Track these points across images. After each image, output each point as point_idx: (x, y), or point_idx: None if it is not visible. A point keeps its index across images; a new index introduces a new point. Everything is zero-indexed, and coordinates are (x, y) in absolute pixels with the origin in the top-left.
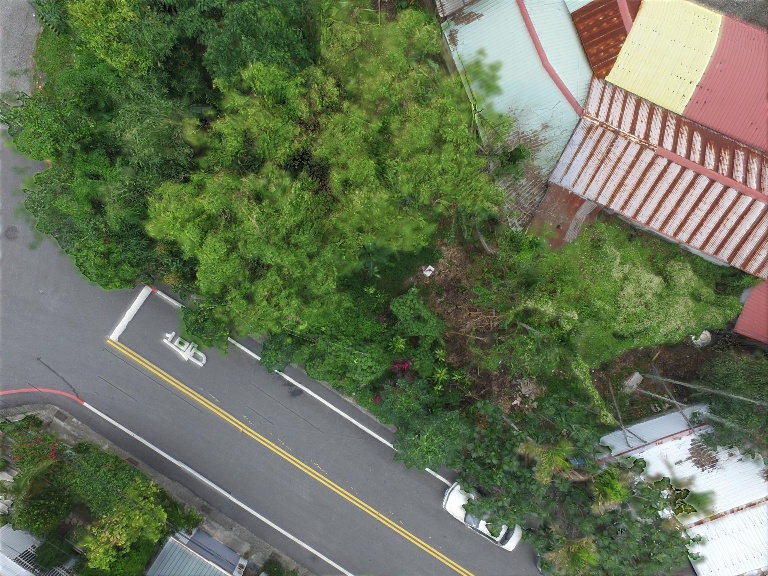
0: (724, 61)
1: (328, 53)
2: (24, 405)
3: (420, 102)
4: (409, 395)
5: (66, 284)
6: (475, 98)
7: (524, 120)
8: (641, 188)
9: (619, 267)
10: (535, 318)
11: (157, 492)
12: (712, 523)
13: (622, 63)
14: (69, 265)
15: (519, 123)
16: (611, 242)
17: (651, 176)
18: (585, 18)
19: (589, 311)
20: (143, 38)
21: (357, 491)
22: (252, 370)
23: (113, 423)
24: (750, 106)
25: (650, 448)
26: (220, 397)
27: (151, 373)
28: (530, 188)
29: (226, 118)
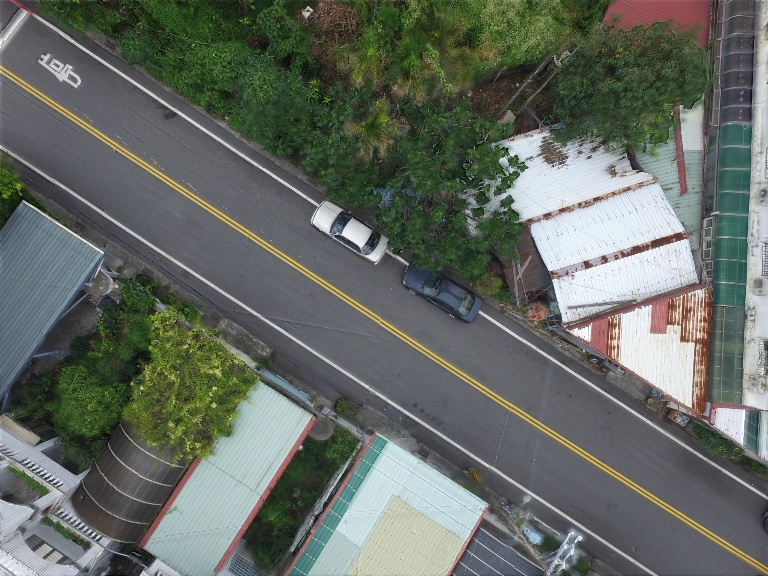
0: None
1: None
2: None
3: None
4: None
5: None
6: None
7: None
8: None
9: None
10: None
11: None
12: (563, 221)
13: None
14: None
15: None
16: None
17: None
18: None
19: None
20: None
21: (228, 210)
22: (126, 93)
23: None
24: None
25: (502, 144)
26: (94, 118)
27: (25, 92)
28: None
29: None
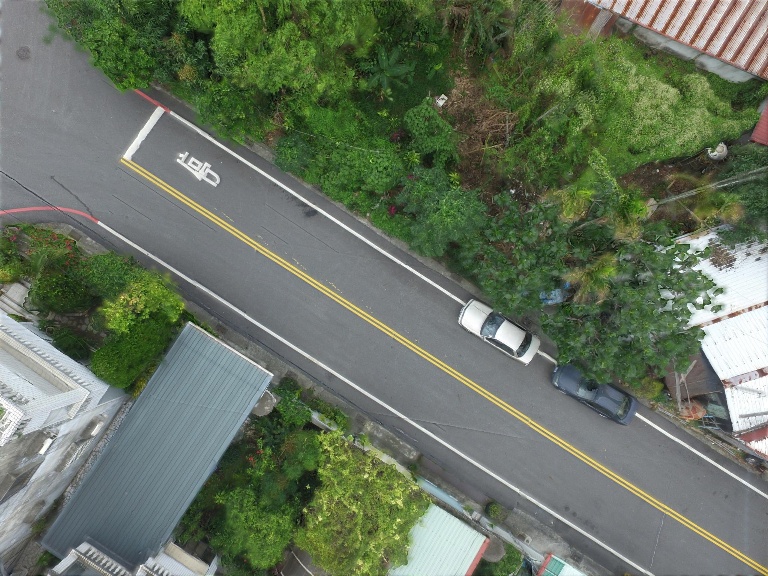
0: None
1: None
2: (38, 223)
3: None
4: (426, 181)
5: (79, 104)
6: None
7: None
8: None
9: (635, 78)
10: (552, 106)
11: None
12: (730, 325)
13: None
14: (81, 85)
15: None
16: (626, 57)
17: None
18: None
19: (607, 98)
20: None
21: (372, 310)
22: (266, 191)
23: (127, 242)
24: None
25: (667, 247)
26: (234, 217)
27: (165, 192)
28: (544, 3)
29: None
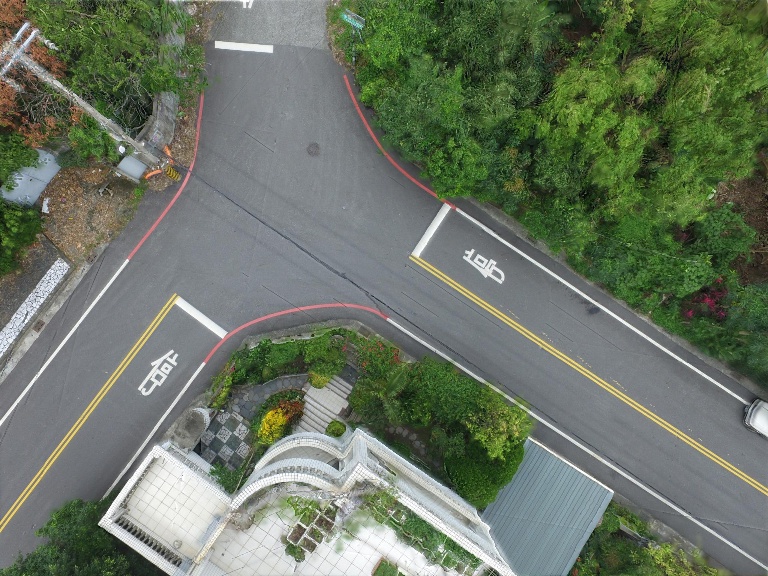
0: None
1: None
2: (329, 320)
3: None
4: (762, 299)
5: (367, 200)
6: None
7: None
8: None
9: None
10: None
11: None
12: None
13: None
14: (369, 182)
15: None
16: None
17: None
18: None
19: None
20: None
21: (656, 408)
22: (549, 288)
23: (415, 339)
24: None
25: None
26: (519, 314)
27: (452, 289)
28: None
29: (535, 32)
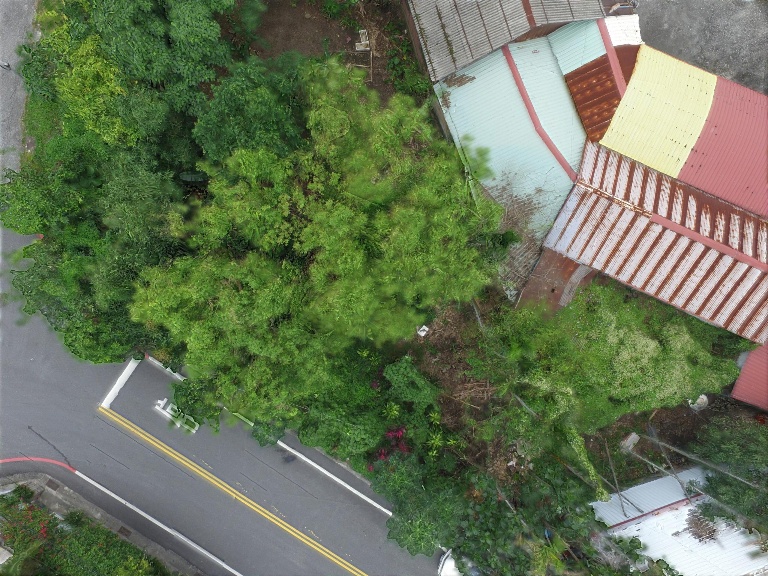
0: (719, 124)
1: (317, 136)
2: (15, 474)
3: (413, 159)
4: (402, 472)
5: (57, 351)
6: (468, 161)
7: (517, 184)
8: (636, 254)
9: (614, 332)
10: (529, 392)
11: (149, 566)
12: None
13: (616, 127)
14: (60, 332)
15: (512, 186)
16: (606, 305)
17: (646, 242)
18: (578, 80)
19: (584, 385)
20: (131, 113)
21: (352, 558)
22: (245, 436)
23: (105, 491)
24: (746, 170)
25: (646, 519)
26: (213, 464)
27: (143, 440)
28: (524, 251)
29: (217, 184)
